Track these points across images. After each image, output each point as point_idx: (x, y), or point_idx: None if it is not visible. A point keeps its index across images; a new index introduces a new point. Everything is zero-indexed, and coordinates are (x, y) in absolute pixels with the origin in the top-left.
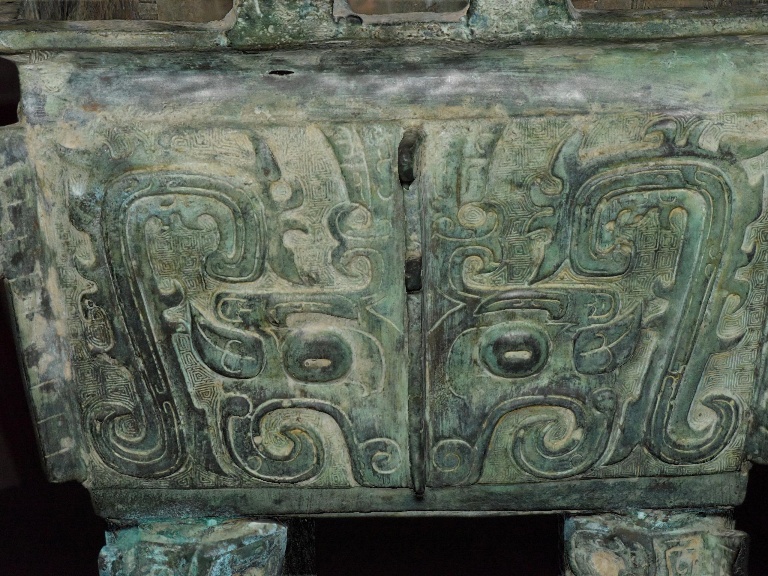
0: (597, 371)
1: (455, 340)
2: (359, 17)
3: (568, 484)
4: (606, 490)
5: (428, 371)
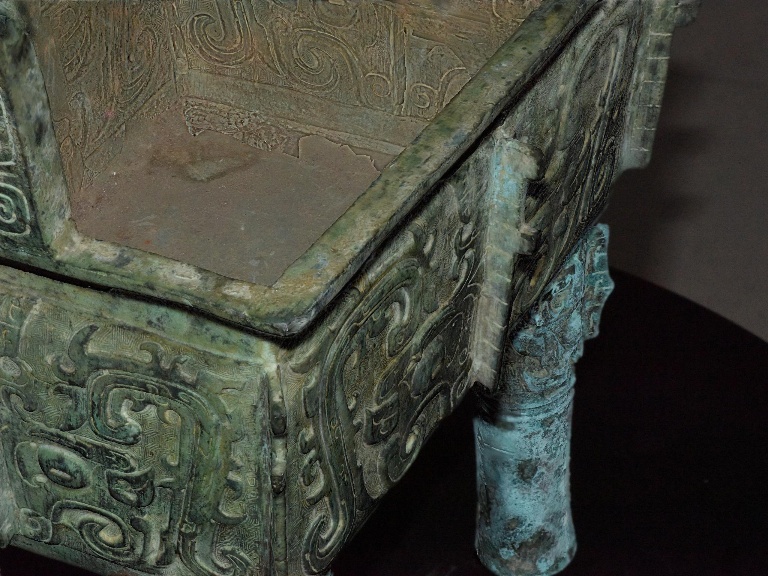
0: (286, 5)
1: (374, 5)
2: None
3: (300, 98)
4: (275, 98)
5: (391, 31)
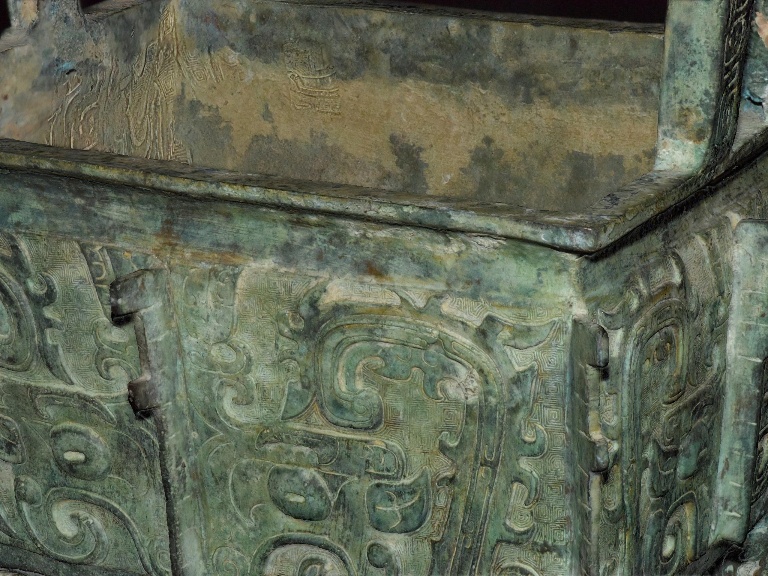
0: None
1: None
2: (5, 33)
3: None
4: None
5: None
